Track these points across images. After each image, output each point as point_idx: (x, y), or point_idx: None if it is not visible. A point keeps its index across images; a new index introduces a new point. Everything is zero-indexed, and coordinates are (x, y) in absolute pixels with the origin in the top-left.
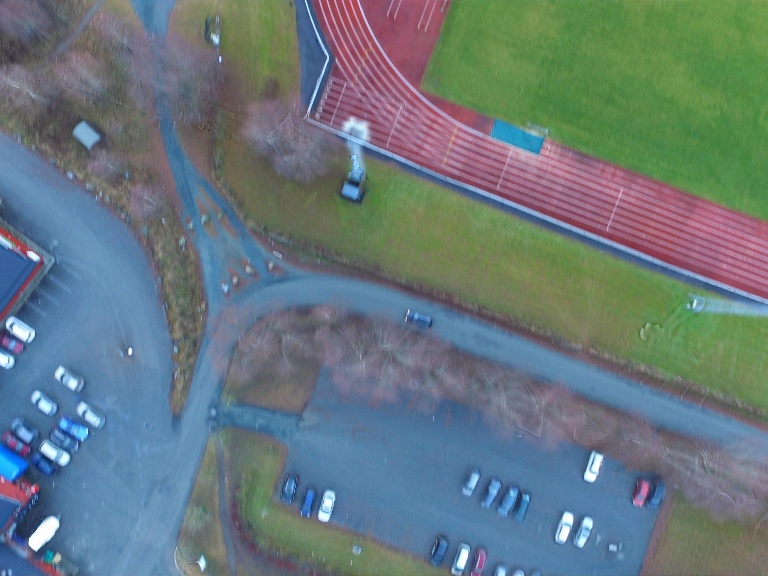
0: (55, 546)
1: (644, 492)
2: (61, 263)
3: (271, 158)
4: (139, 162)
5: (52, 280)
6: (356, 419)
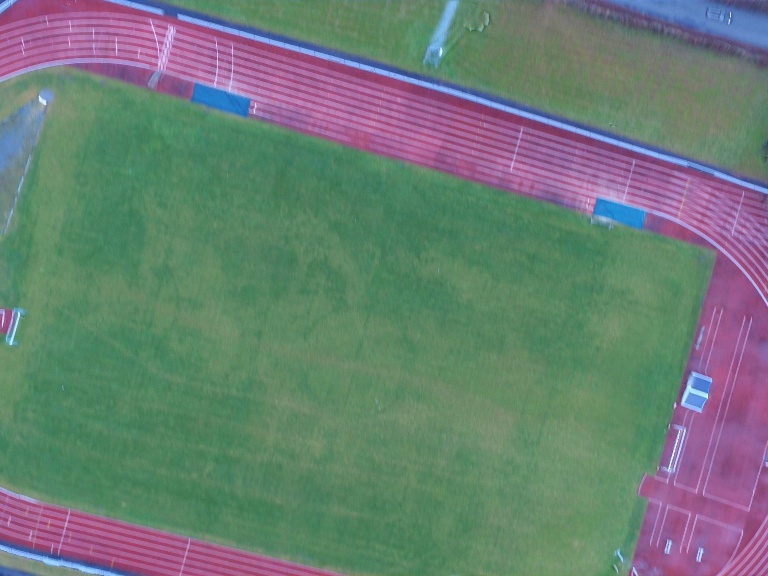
0: None
1: None
2: None
3: None
4: None
5: None
6: None
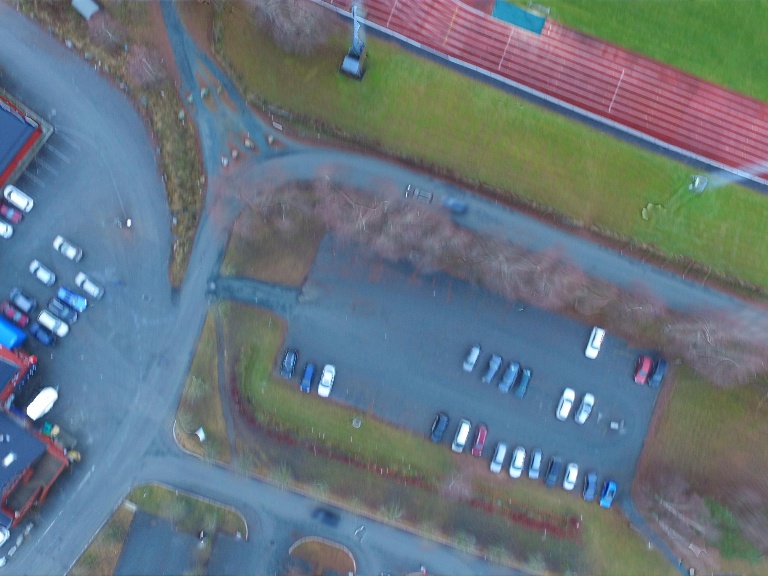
0: (53, 418)
1: (646, 368)
2: (60, 133)
3: (271, 32)
4: (138, 36)
5: (50, 150)
6: (356, 294)
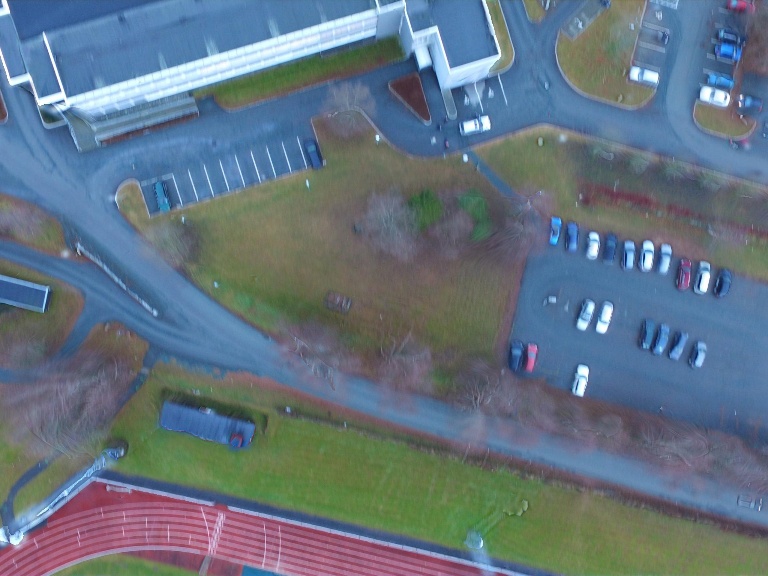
0: None
1: (532, 361)
2: None
3: None
4: None
5: None
6: None
